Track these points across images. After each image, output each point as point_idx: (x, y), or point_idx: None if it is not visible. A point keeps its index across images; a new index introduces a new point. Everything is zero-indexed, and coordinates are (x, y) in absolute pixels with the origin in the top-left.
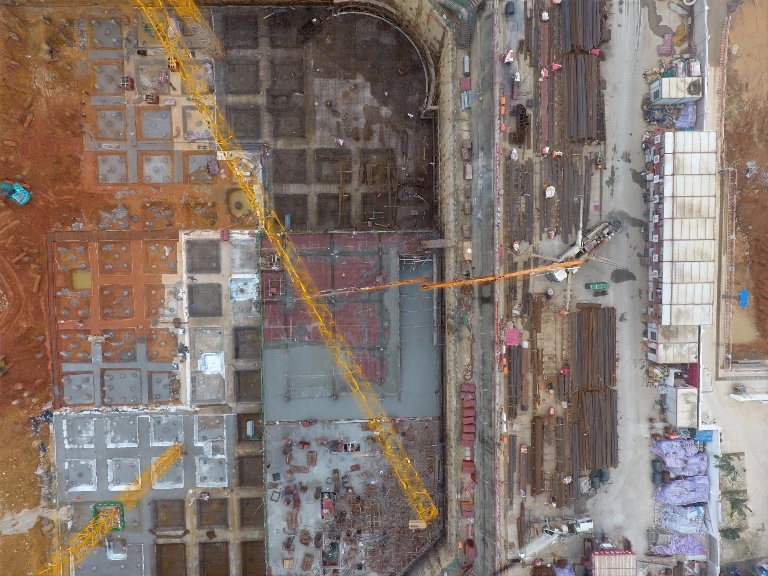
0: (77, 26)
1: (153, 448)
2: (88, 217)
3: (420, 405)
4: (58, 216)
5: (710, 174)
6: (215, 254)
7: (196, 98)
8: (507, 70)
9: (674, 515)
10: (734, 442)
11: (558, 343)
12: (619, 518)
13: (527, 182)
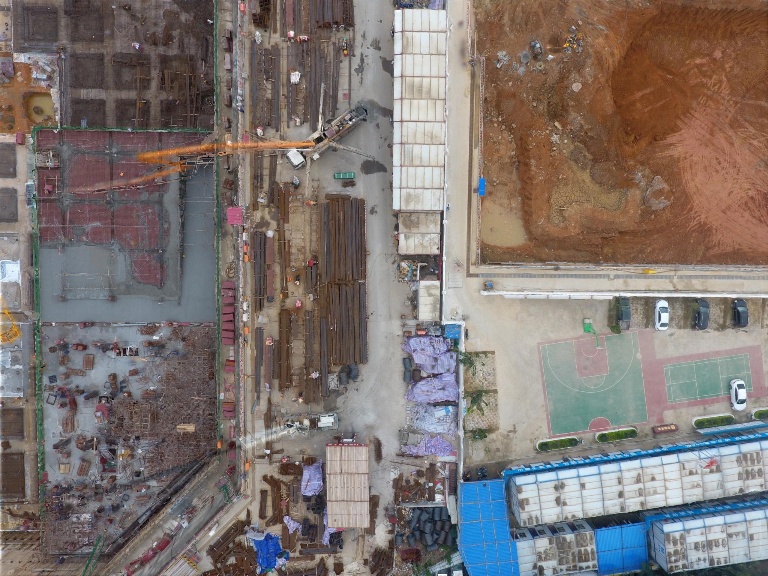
0: None
1: None
2: None
3: (201, 310)
4: None
5: (440, 54)
6: (12, 159)
7: None
8: None
9: (425, 415)
10: (484, 340)
11: (307, 235)
12: (370, 417)
13: (273, 67)
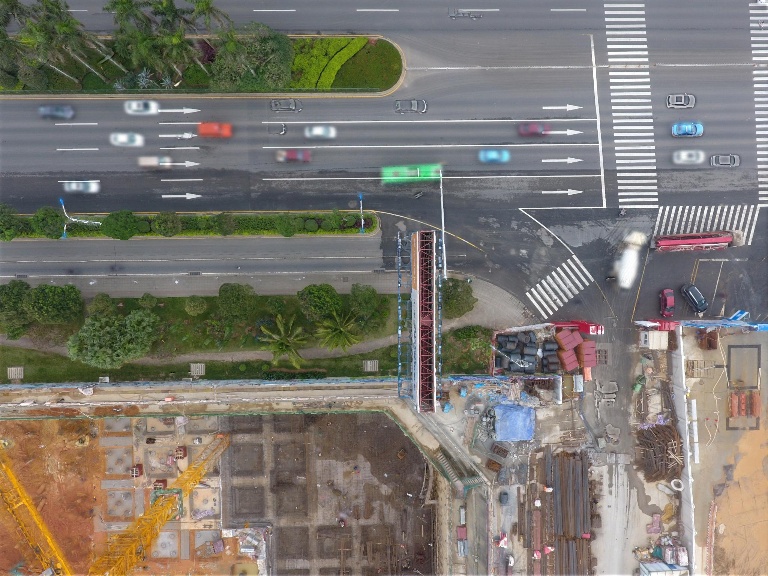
0: None
1: None
2: None
3: None
4: None
5: None
6: None
7: (202, 480)
8: (501, 550)
9: None
10: None
11: None
12: None
13: None
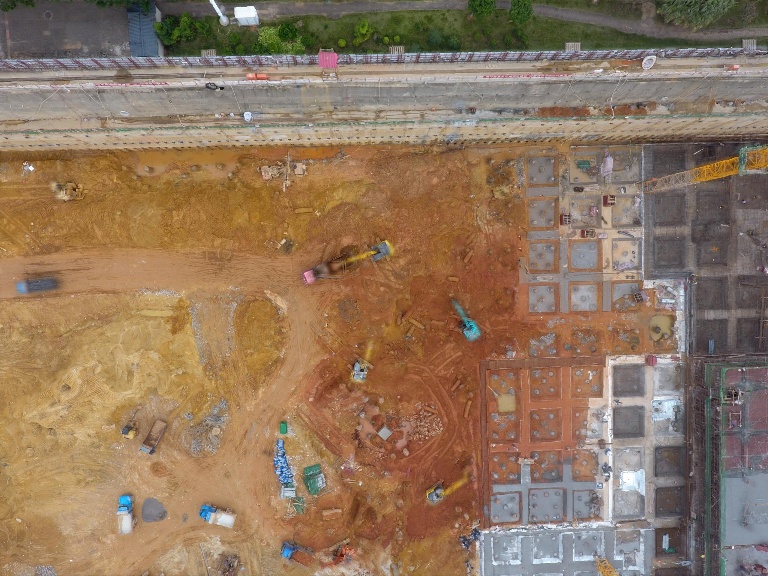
0: (516, 165)
1: (576, 563)
2: (521, 346)
3: None
4: (491, 345)
5: None
6: (636, 377)
7: (626, 231)
8: None
9: None
10: None
11: None
12: None
13: None
